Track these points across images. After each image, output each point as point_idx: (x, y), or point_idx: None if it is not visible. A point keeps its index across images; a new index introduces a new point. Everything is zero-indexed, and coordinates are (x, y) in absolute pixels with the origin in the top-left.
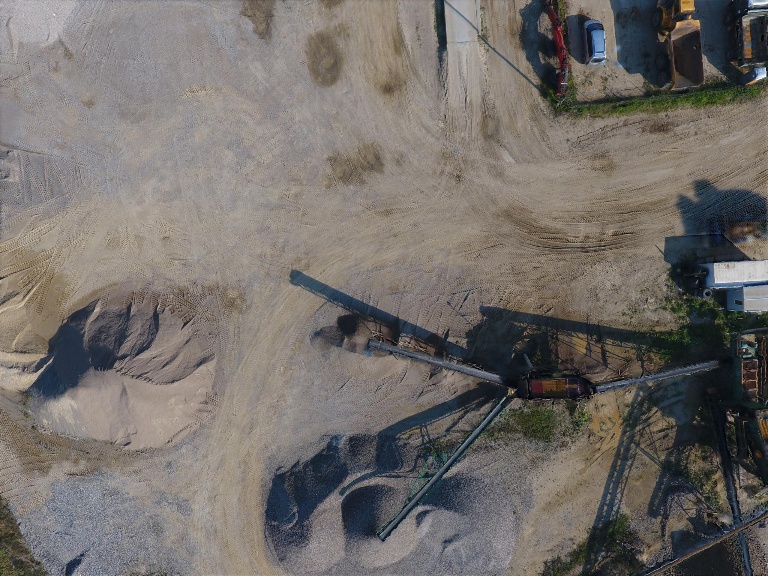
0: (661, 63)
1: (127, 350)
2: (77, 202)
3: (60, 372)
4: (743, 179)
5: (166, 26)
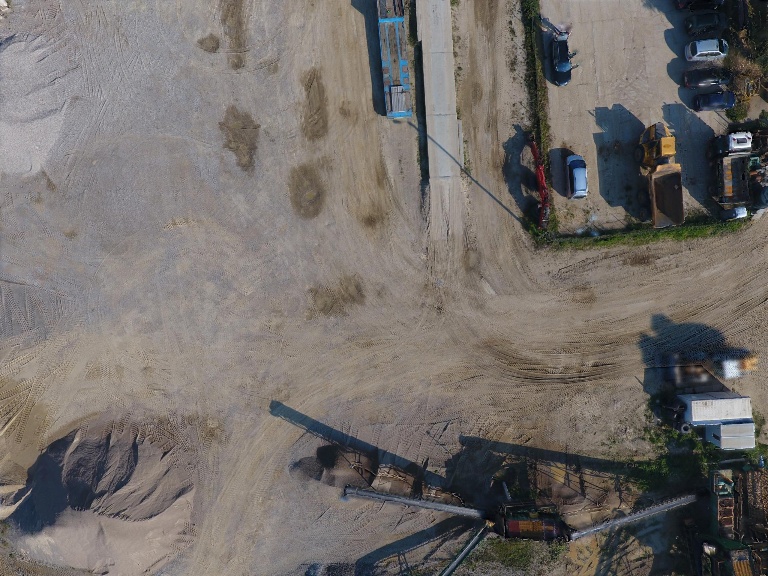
0: (642, 199)
1: (105, 486)
2: (58, 332)
3: (38, 506)
4: (723, 311)
5: (149, 158)
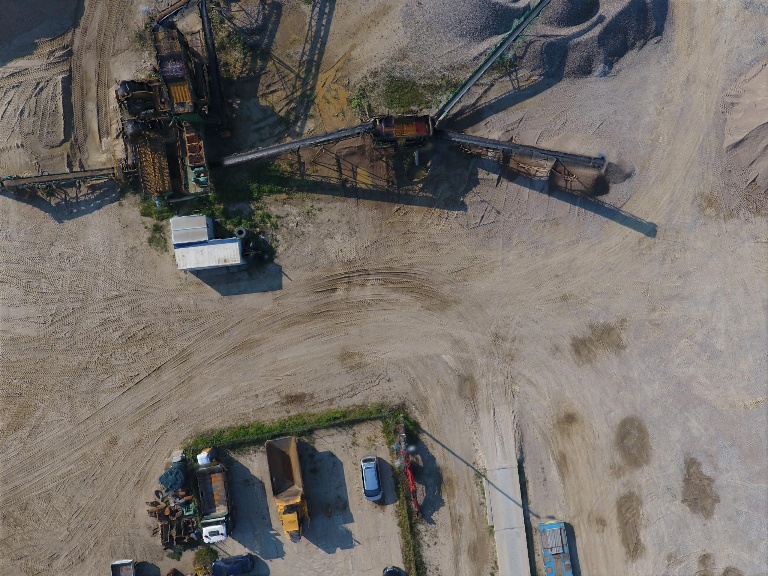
0: None
1: None
2: None
3: None
4: (204, 353)
5: None
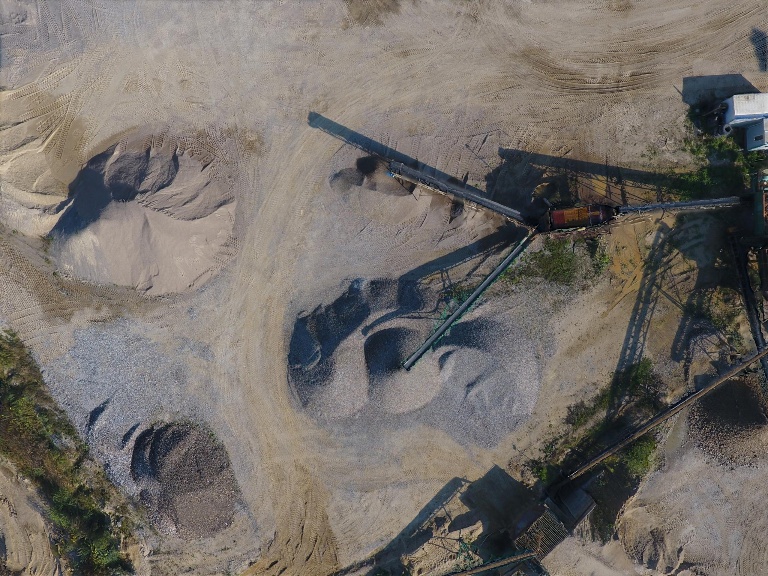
0: None
1: (148, 186)
2: (94, 45)
3: (81, 211)
4: (760, 18)
5: None
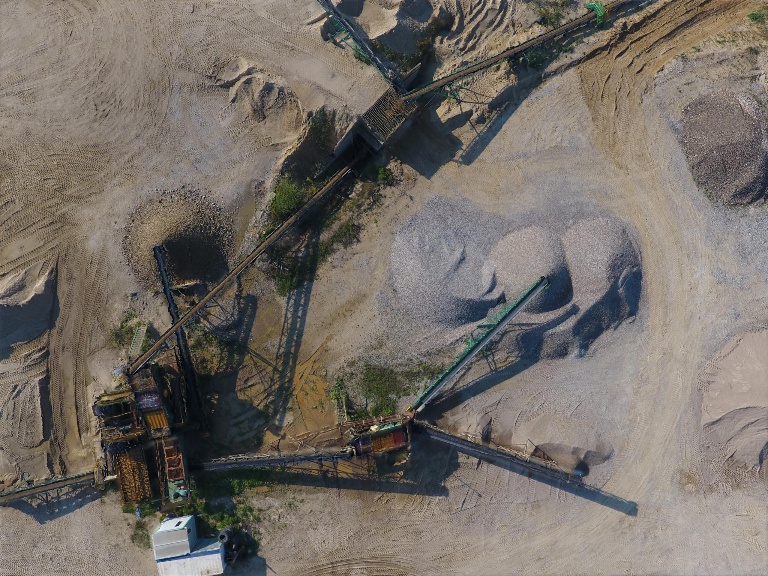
0: None
1: None
2: None
3: None
4: None
5: None
